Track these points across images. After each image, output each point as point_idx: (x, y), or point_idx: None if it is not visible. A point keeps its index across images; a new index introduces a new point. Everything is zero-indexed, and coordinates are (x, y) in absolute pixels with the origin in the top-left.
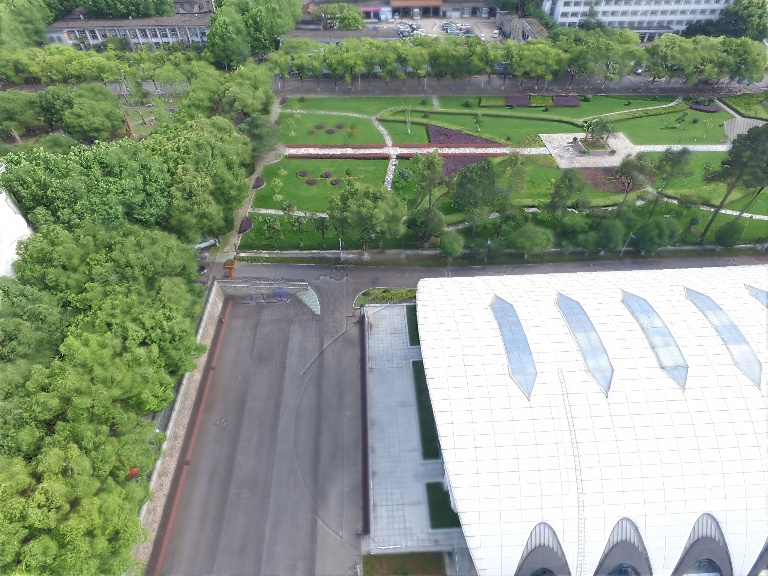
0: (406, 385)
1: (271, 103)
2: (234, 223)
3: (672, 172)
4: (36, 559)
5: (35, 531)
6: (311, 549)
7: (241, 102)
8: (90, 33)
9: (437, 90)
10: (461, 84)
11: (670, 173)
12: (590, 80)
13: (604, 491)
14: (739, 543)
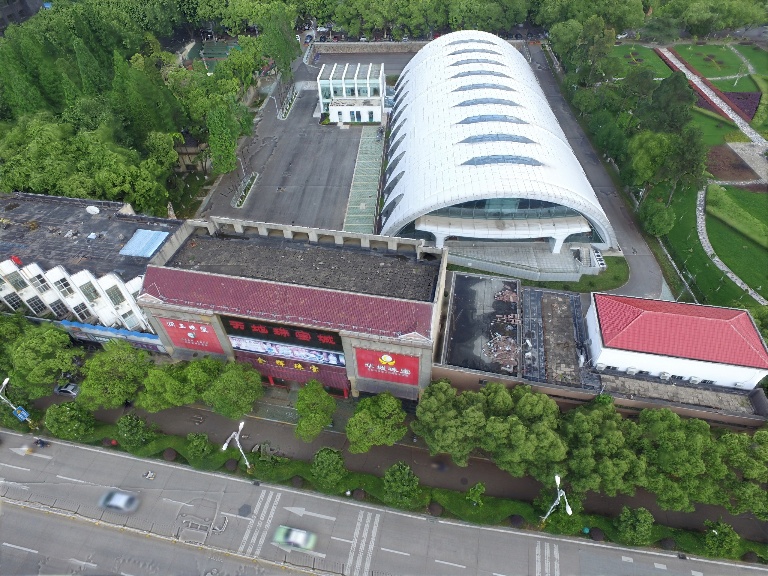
0: None
1: (714, 28)
2: None
3: None
4: (403, 2)
5: None
6: None
7: (688, 12)
8: None
9: None
10: None
11: None
12: None
13: None
14: None
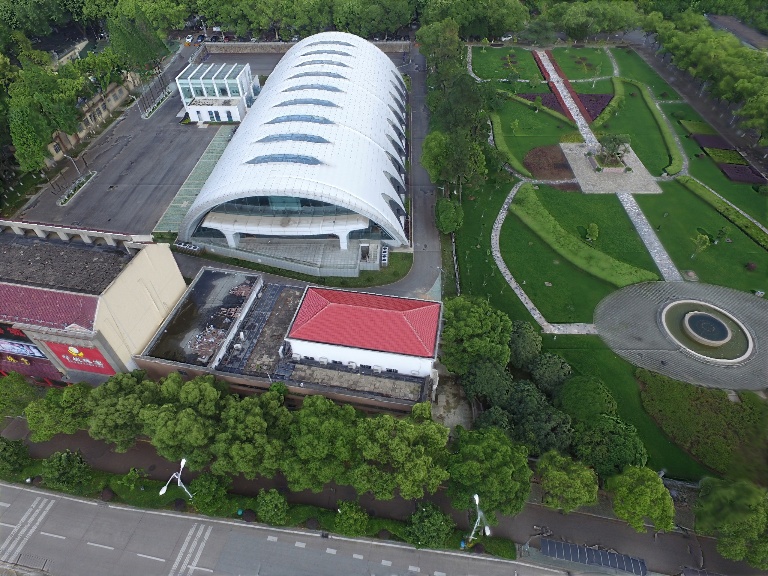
0: None
1: (590, 32)
2: None
3: None
4: (287, 3)
5: (293, 2)
6: None
7: (566, 16)
8: None
9: (703, 102)
10: None
11: None
12: None
13: None
14: None
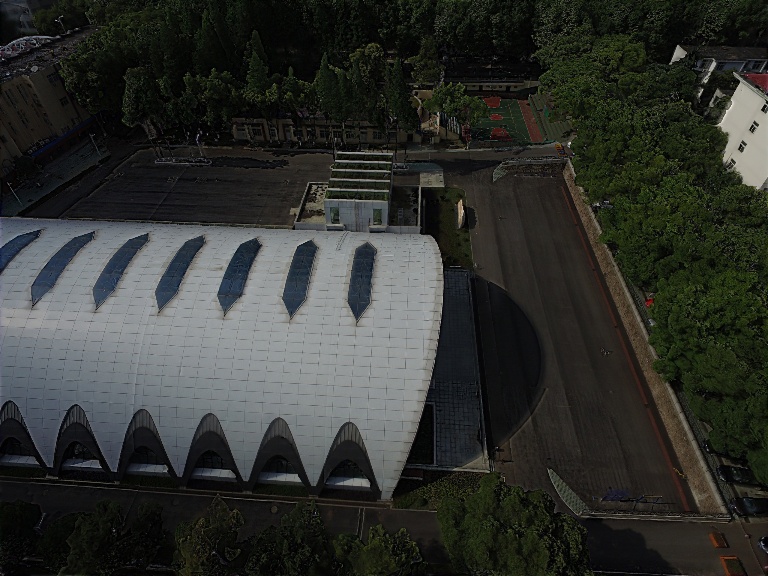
0: (441, 364)
1: None
2: None
3: None
4: None
5: None
6: (506, 277)
7: None
8: None
9: None
10: None
11: None
12: None
13: None
14: None
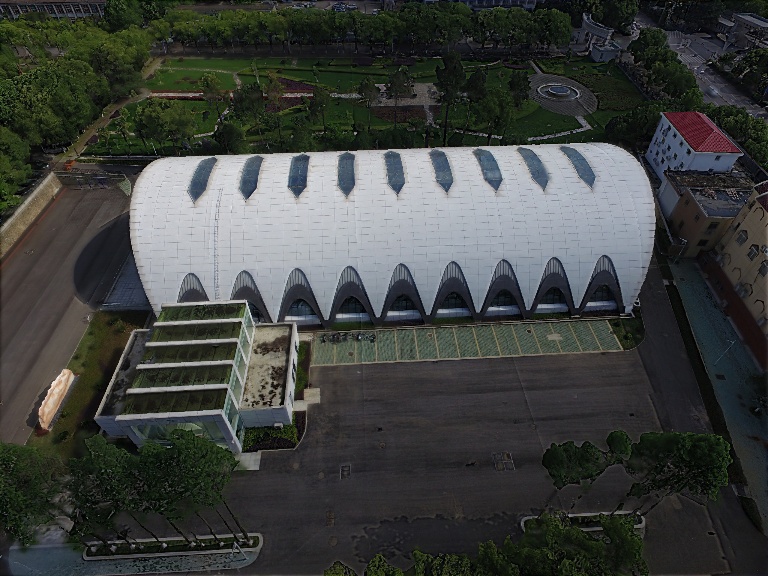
0: None
1: (145, 59)
2: (84, 139)
3: (396, 91)
4: None
5: None
6: (63, 310)
7: (113, 55)
8: (13, 9)
9: (300, 54)
10: (323, 49)
11: (396, 92)
12: (435, 47)
13: (231, 254)
14: (320, 288)
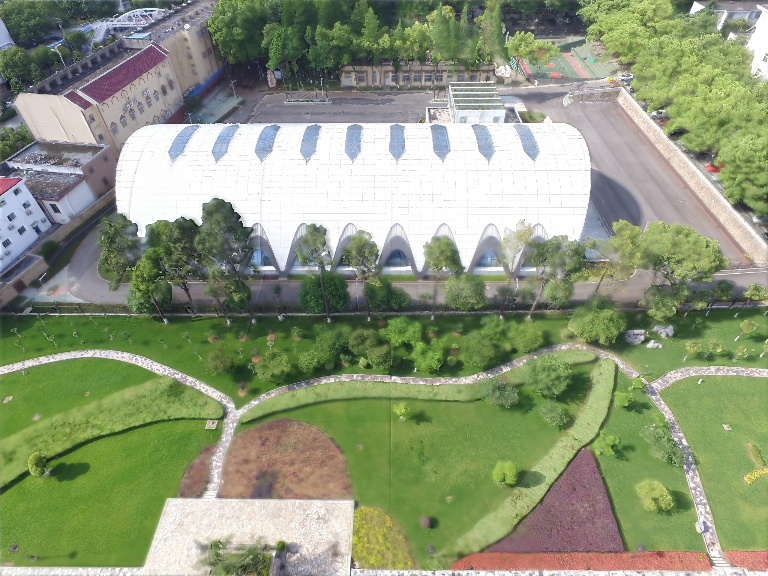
0: None
1: None
2: None
3: None
4: None
5: None
6: None
7: None
8: None
9: None
10: None
11: None
12: None
13: None
14: None
